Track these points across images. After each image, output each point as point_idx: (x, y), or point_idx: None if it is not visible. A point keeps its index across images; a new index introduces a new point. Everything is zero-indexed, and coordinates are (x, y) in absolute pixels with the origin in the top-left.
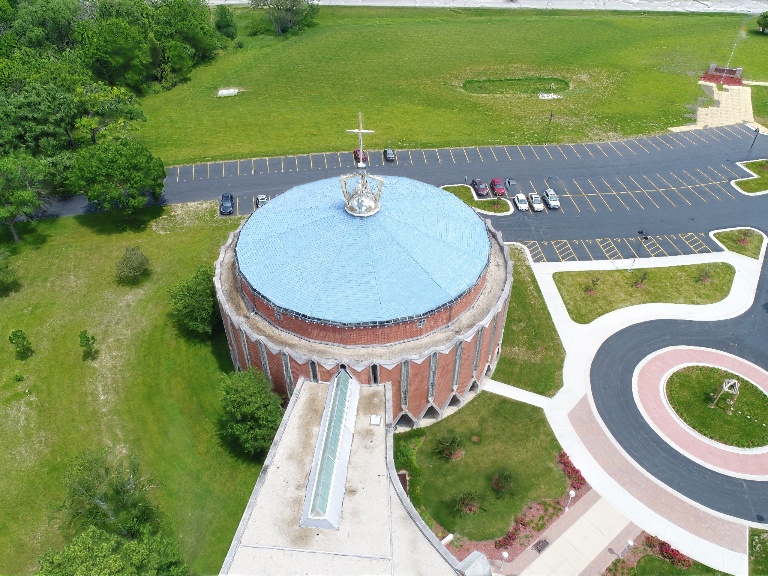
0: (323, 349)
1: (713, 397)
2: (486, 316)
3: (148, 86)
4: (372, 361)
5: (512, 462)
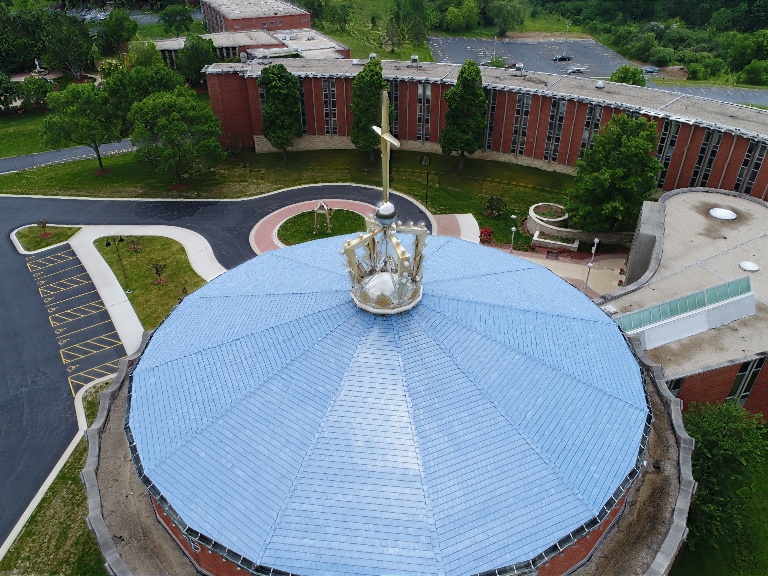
0: None
1: (318, 232)
2: None
3: None
4: None
5: None
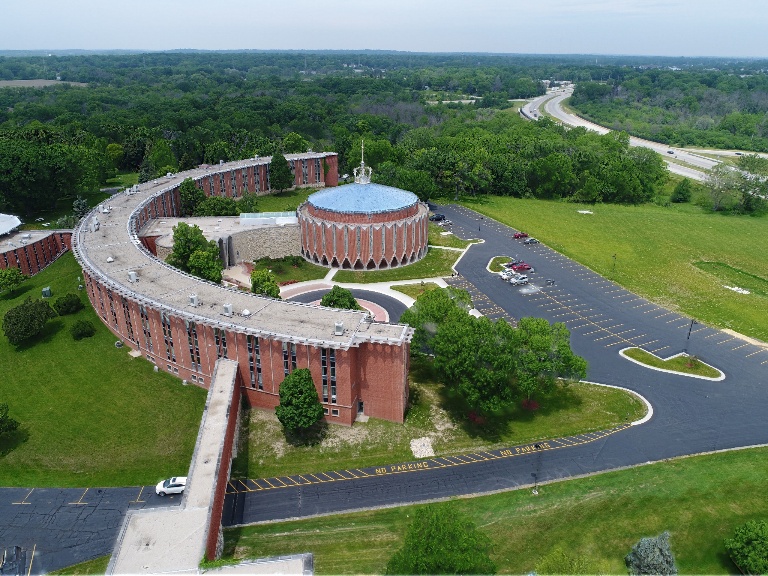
0: None
1: None
2: None
3: (565, 197)
4: None
5: None
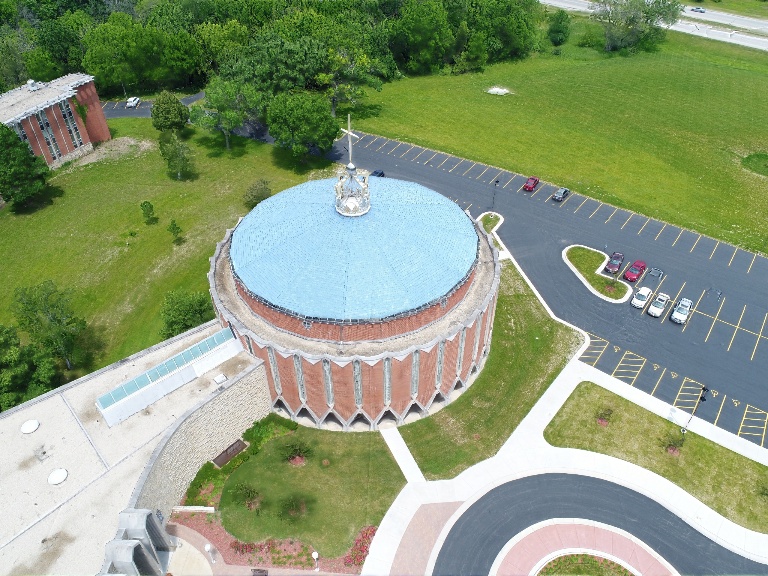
0: (238, 305)
1: None
2: (377, 355)
3: (442, 67)
4: (248, 331)
5: (327, 501)
